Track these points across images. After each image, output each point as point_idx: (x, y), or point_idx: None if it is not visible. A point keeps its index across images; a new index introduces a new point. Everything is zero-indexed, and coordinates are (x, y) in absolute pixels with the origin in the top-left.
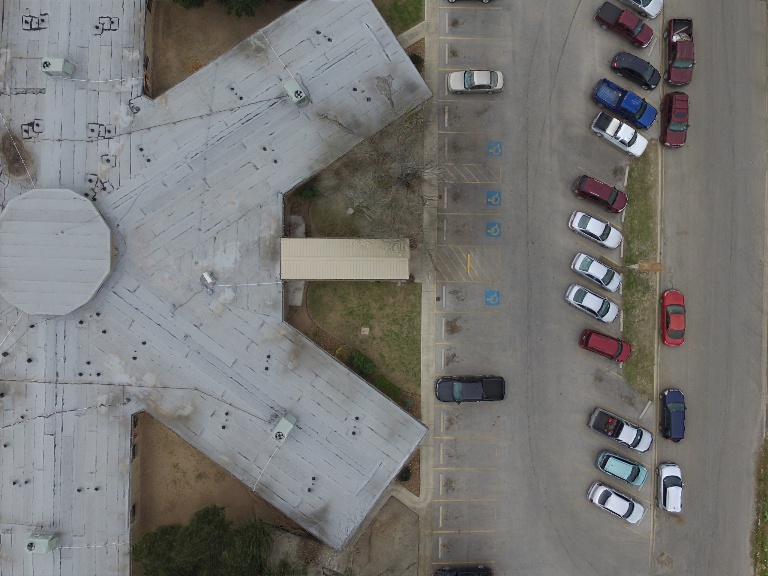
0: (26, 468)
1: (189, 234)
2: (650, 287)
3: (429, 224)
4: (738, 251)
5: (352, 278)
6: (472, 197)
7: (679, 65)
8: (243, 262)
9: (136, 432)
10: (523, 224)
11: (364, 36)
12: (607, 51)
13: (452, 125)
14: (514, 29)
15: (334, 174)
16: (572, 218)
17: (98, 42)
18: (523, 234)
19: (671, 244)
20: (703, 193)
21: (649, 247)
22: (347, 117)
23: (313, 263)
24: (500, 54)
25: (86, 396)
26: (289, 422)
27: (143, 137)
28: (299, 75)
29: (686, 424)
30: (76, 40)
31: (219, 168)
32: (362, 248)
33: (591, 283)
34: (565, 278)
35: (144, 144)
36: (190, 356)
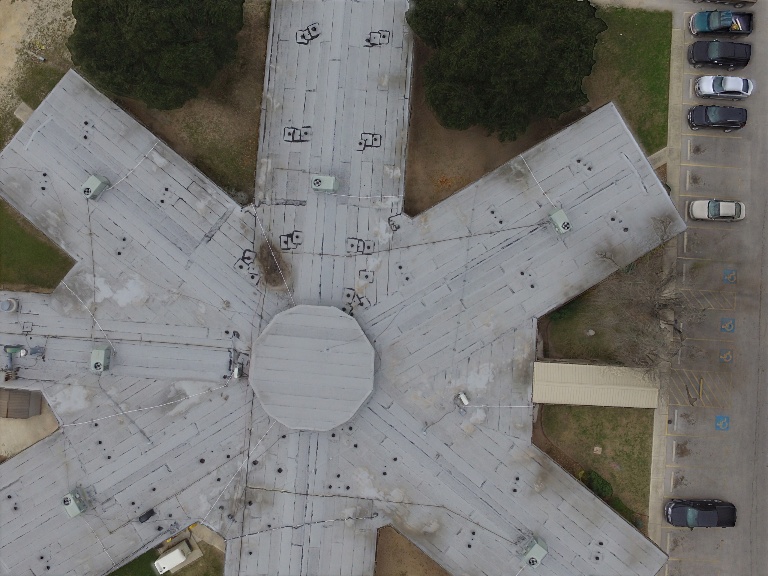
0: (270, 575)
1: (444, 353)
2: None
3: None
4: None
5: (601, 405)
6: (707, 323)
7: None
8: (496, 384)
9: None
10: (755, 352)
11: (624, 167)
12: None
13: (690, 251)
14: (753, 159)
15: (613, 314)
16: None
17: (360, 158)
18: (754, 362)
19: None
20: None
21: None
22: (603, 246)
23: (565, 389)
24: (739, 183)
25: (334, 508)
26: (543, 549)
27: (401, 255)
28: (560, 203)
29: None
30: (339, 155)
31: (476, 290)
32: (613, 376)
33: None
34: None
35: (402, 262)
36: (441, 475)
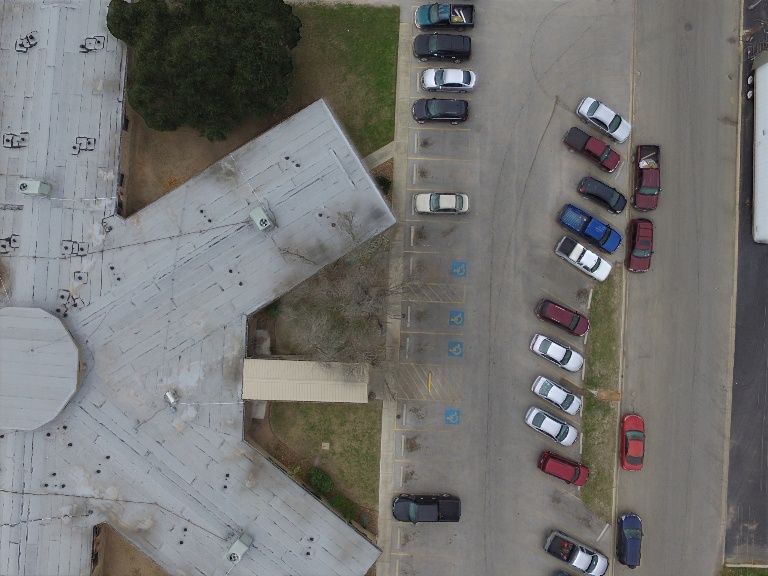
0: None
1: (155, 352)
2: (611, 410)
3: (392, 342)
4: (701, 376)
5: (312, 400)
6: (435, 316)
7: (645, 192)
8: (206, 381)
9: (99, 540)
10: (485, 344)
11: (331, 163)
12: (574, 174)
13: (417, 245)
14: (482, 151)
15: (292, 309)
16: (533, 341)
17: (75, 161)
18: (485, 354)
19: (633, 368)
20: (667, 317)
21: (611, 370)
22: (312, 242)
23: (274, 385)
24: (467, 175)
25: (51, 506)
26: (244, 544)
27: (114, 255)
28: (266, 200)
29: (644, 548)
30: (54, 159)
31: (186, 288)
32: (322, 371)
33: (551, 405)
34: (525, 399)
35: (115, 262)
36: (152, 472)
